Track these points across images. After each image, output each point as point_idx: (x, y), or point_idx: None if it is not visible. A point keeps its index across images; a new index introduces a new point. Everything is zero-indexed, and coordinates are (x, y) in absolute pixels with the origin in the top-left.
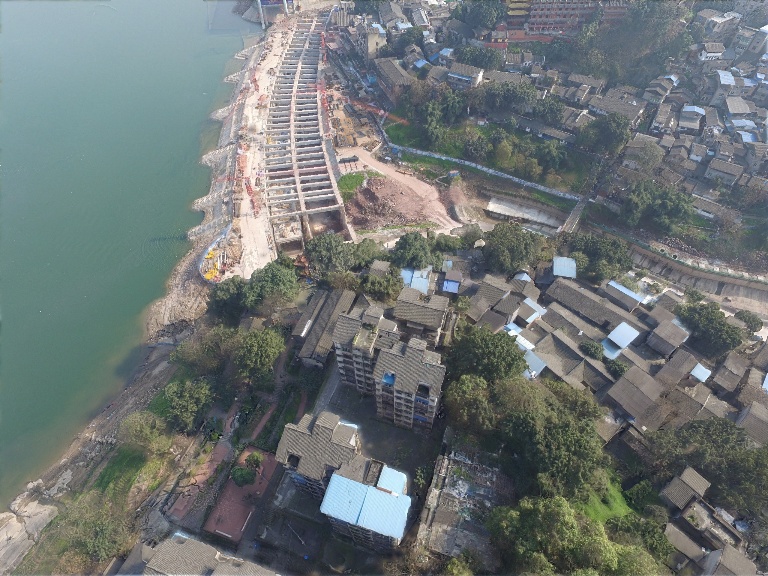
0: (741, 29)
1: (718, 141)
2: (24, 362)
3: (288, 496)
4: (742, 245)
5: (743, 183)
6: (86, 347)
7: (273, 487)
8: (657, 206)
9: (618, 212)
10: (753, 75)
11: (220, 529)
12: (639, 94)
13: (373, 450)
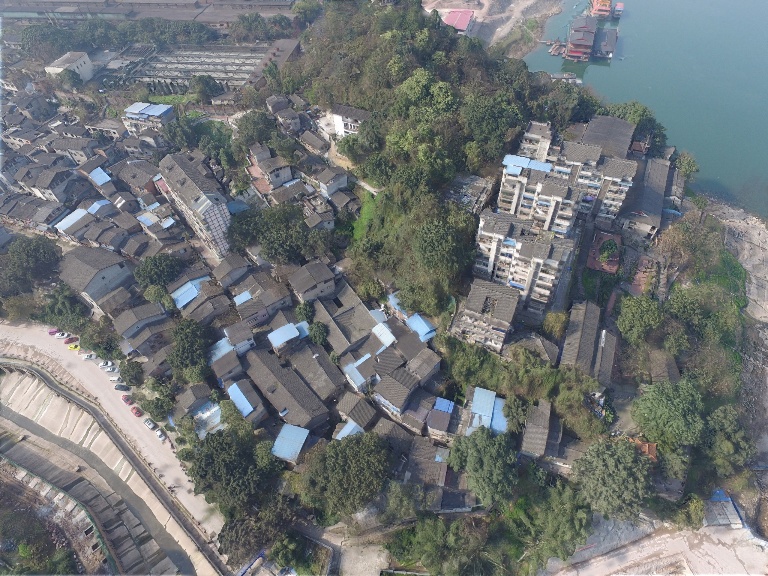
0: None
1: None
2: None
3: (572, 232)
4: None
5: None
6: None
7: (584, 251)
8: None
9: None
10: None
11: (610, 236)
12: None
13: None
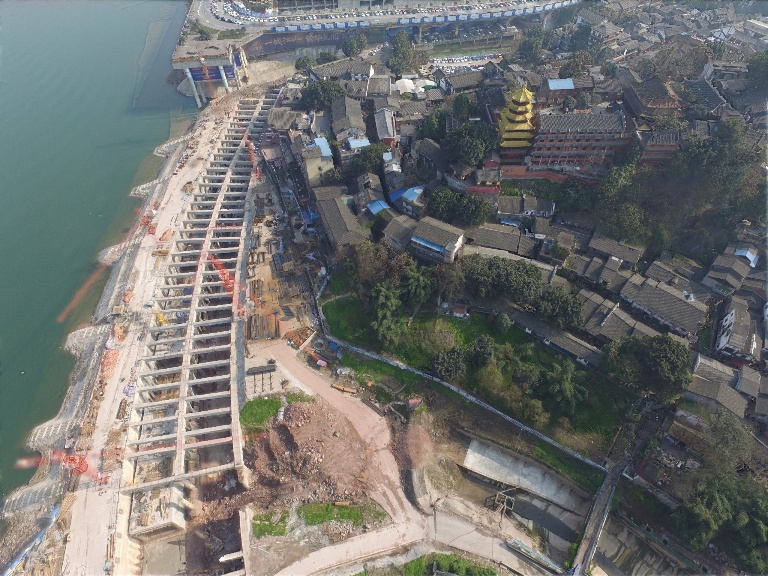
0: None
1: None
2: None
3: None
4: None
5: None
6: None
7: None
8: (741, 526)
9: (671, 506)
10: None
11: None
12: (696, 275)
13: None
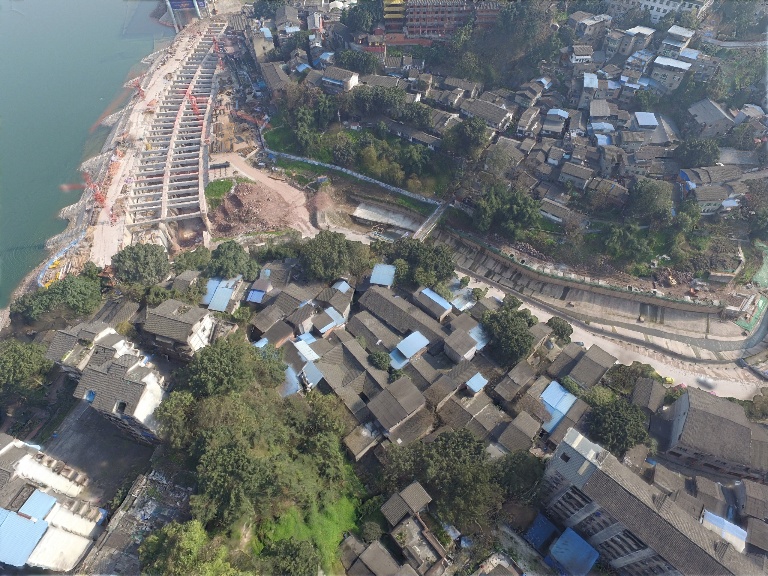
0: (611, 31)
1: (574, 144)
2: None
3: None
4: (588, 249)
5: (593, 187)
6: None
7: None
8: (506, 211)
9: None
10: (619, 78)
11: None
12: (512, 97)
13: (105, 468)
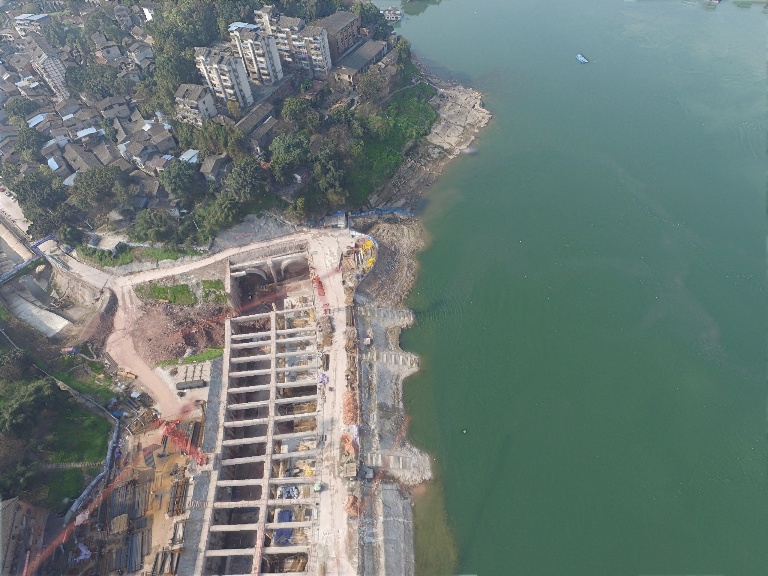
0: None
1: None
2: (506, 209)
3: (288, 76)
4: None
5: None
6: (465, 218)
7: (298, 89)
8: None
9: None
10: None
11: (321, 82)
12: None
13: None
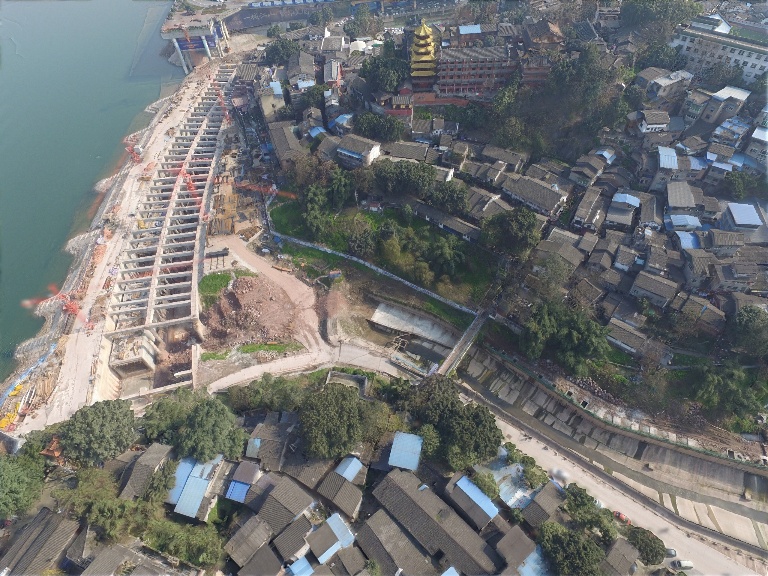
0: (692, 93)
1: (649, 246)
2: None
3: None
4: (671, 393)
5: (677, 306)
6: None
7: None
8: (563, 337)
9: None
10: (704, 153)
11: None
12: (565, 173)
13: None
